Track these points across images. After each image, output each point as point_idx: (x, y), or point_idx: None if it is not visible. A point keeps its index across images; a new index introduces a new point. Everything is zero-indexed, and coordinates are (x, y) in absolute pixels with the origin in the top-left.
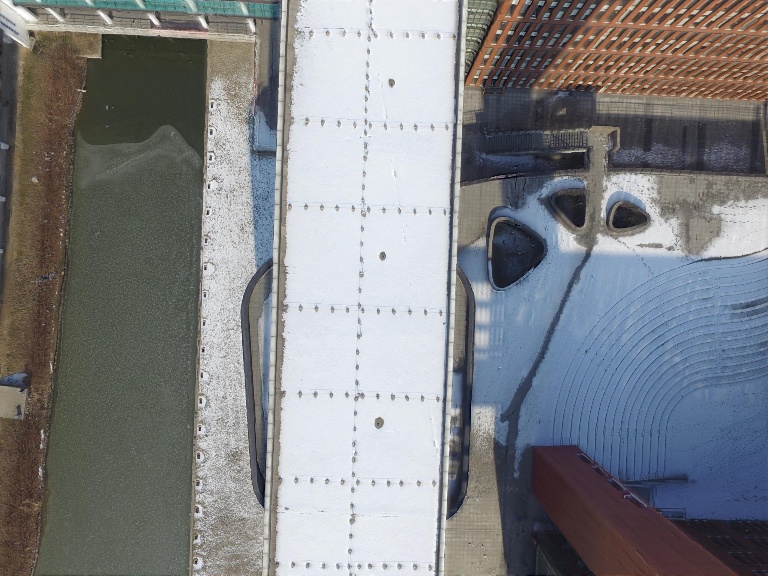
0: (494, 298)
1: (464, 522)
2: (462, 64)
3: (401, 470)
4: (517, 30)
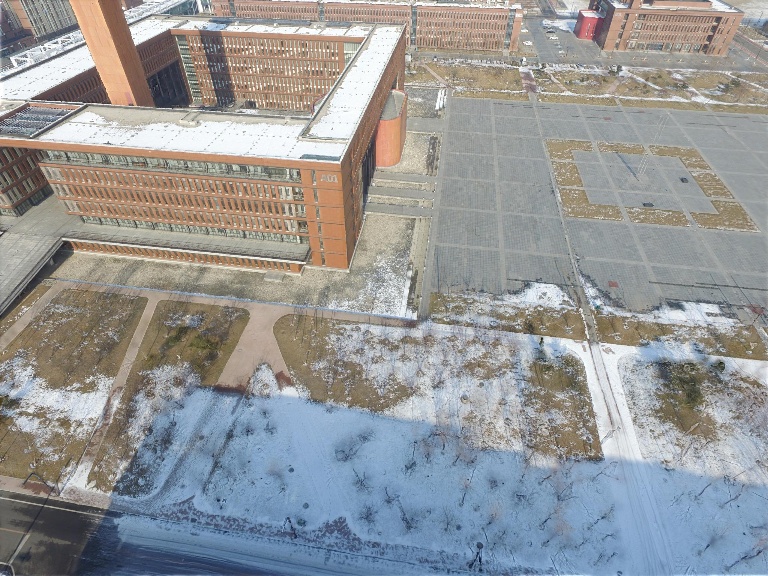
0: None
1: None
2: (155, 35)
3: None
4: (200, 61)
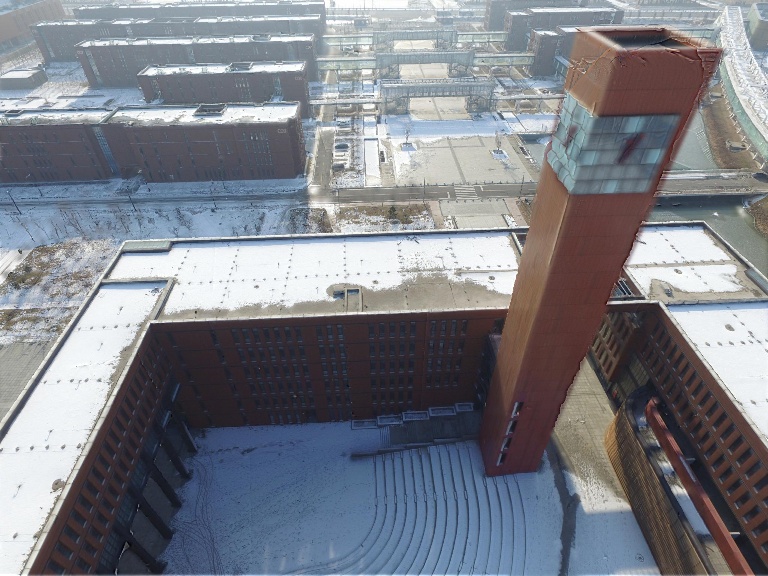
0: None
1: (573, 401)
2: None
3: None
4: None
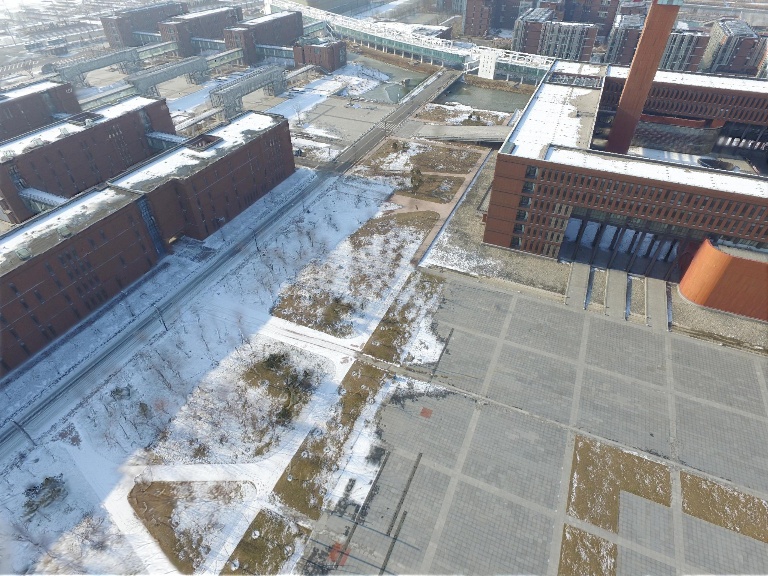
0: (693, 160)
1: None
2: None
3: None
4: None
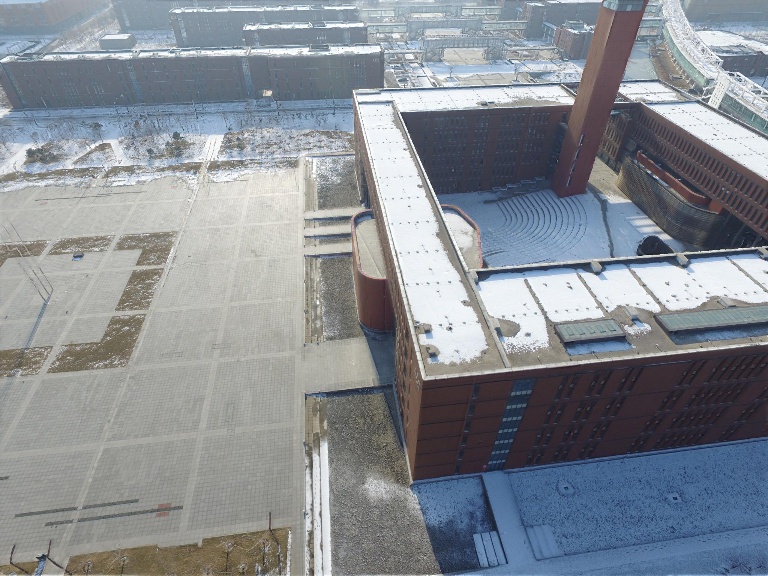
0: None
1: (596, 173)
2: None
3: (694, 127)
4: None
